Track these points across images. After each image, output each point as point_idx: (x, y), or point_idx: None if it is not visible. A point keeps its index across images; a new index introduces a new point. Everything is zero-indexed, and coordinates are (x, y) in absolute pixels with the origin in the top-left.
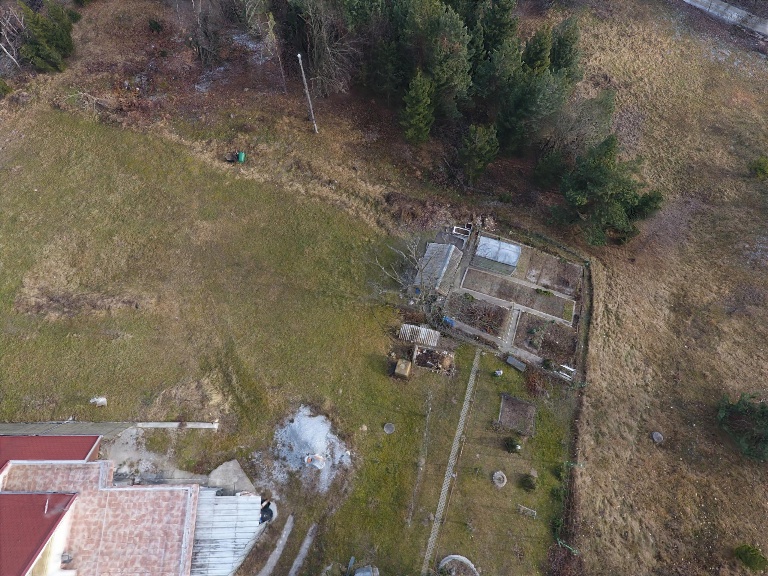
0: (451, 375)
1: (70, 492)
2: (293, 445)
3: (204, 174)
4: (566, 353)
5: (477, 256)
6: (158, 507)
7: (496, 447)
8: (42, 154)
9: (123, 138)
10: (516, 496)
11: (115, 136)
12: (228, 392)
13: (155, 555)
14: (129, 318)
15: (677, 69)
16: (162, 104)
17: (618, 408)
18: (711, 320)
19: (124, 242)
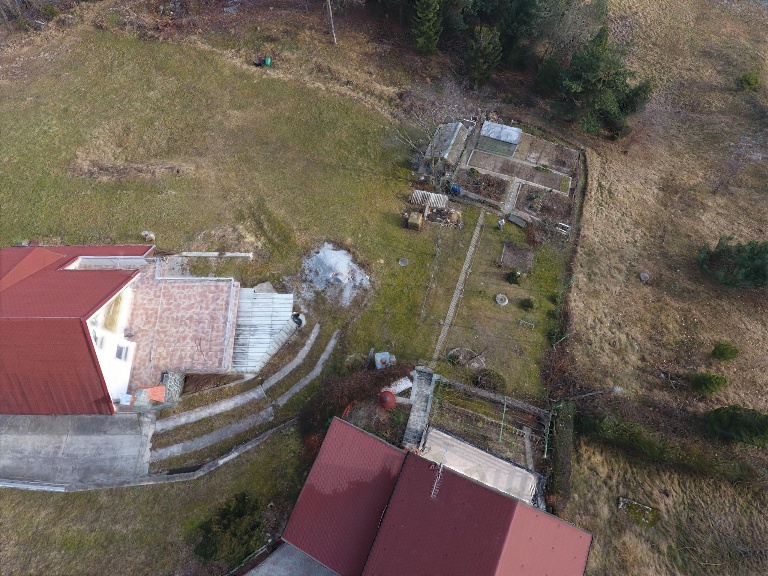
0: (458, 228)
1: (134, 269)
2: (319, 270)
3: (234, 74)
4: (562, 216)
5: (482, 136)
6: (205, 298)
7: (499, 279)
8: (87, 64)
9: (160, 49)
10: (516, 313)
11: (153, 48)
12: (260, 235)
13: (203, 333)
14: (171, 180)
15: (670, 5)
16: (195, 22)
17: (609, 256)
18: (696, 197)
19: (164, 127)
